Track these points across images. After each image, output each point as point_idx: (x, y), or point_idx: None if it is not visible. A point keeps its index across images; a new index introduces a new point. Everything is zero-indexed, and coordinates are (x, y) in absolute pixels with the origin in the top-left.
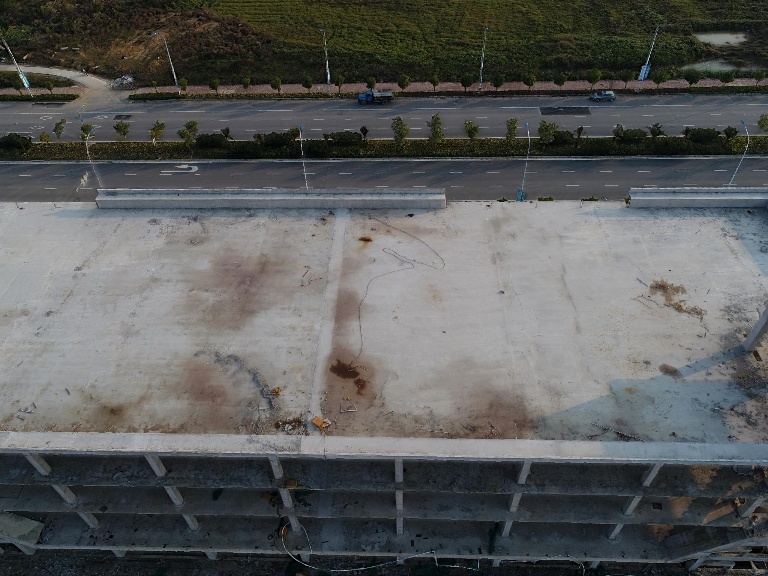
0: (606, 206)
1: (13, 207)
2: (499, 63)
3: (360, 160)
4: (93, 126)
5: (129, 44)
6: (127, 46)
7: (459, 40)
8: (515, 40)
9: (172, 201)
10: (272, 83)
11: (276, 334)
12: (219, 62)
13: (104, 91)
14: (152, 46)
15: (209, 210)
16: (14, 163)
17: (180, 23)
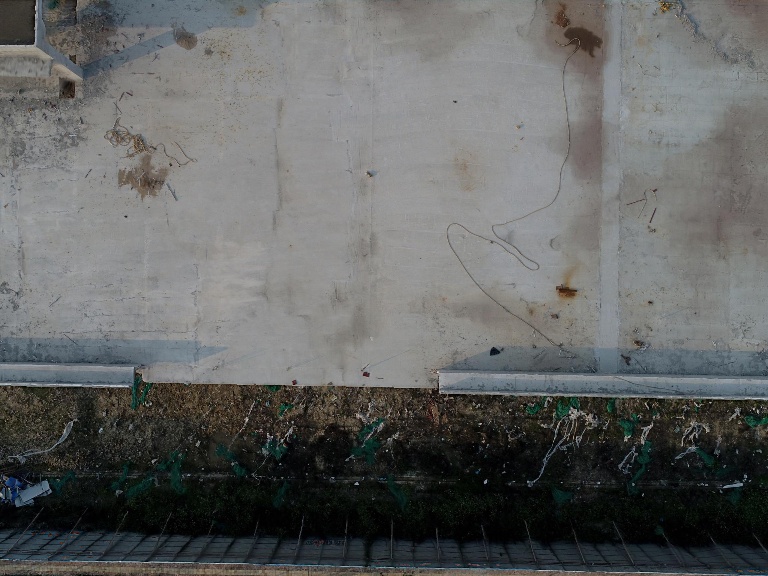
0: (176, 369)
1: None
2: None
3: None
4: None
5: None
6: None
7: None
8: None
9: None
10: None
11: (680, 98)
12: None
13: None
14: None
15: None
16: None
17: None
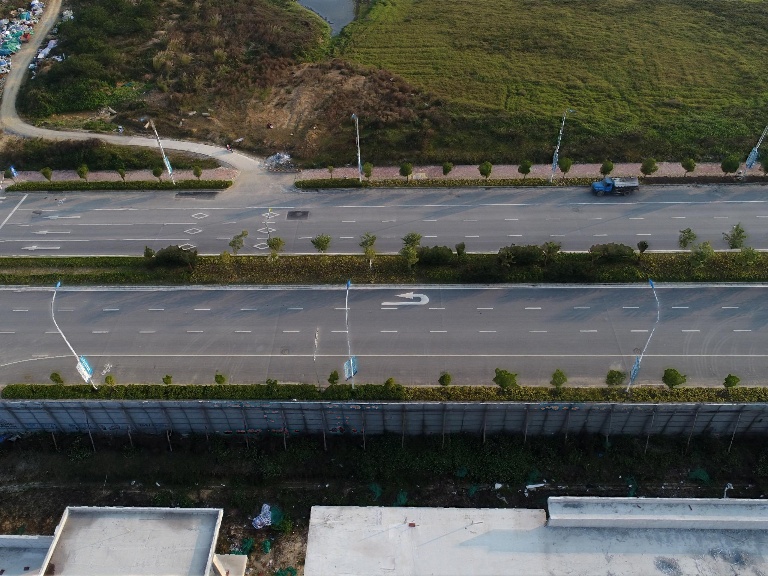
0: None
1: (396, 521)
2: (741, 134)
3: (640, 286)
4: (265, 229)
5: (269, 107)
6: (268, 110)
7: (670, 100)
8: (738, 100)
9: (684, 521)
10: (483, 169)
11: None
12: (390, 133)
13: (260, 175)
14: (299, 110)
15: (746, 535)
16: (182, 289)
17: (320, 78)
